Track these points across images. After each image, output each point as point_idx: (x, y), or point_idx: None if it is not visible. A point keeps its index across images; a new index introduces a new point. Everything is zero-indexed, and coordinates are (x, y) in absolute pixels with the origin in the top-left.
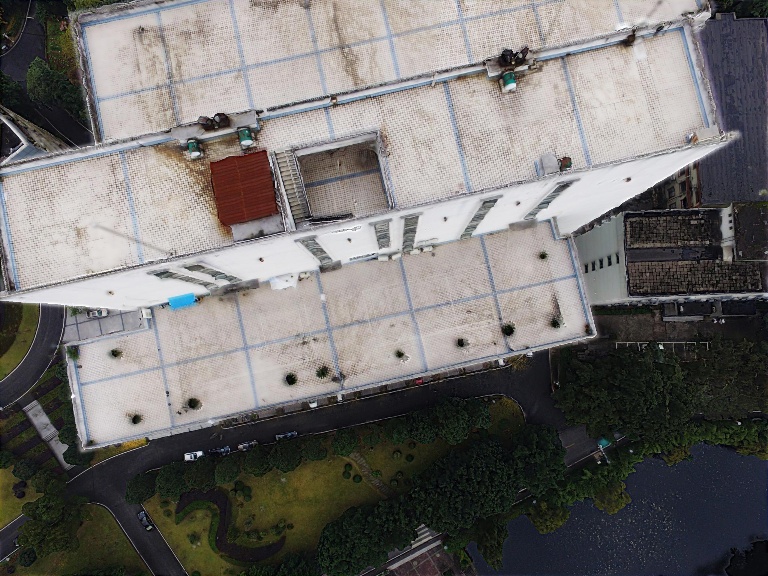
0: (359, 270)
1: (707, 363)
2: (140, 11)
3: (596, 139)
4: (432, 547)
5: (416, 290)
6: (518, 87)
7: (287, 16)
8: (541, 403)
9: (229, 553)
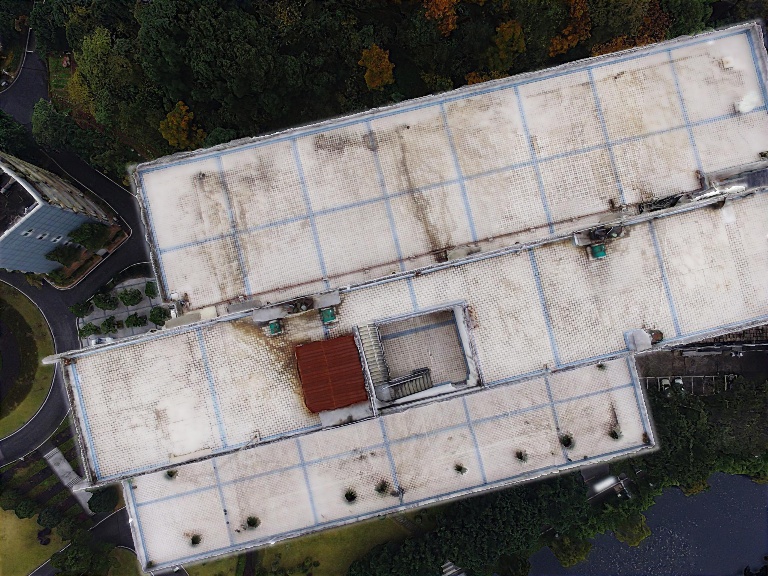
0: None
1: (729, 405)
2: (200, 157)
3: (685, 307)
4: None
5: (473, 401)
6: None
7: (354, 159)
8: None
9: None
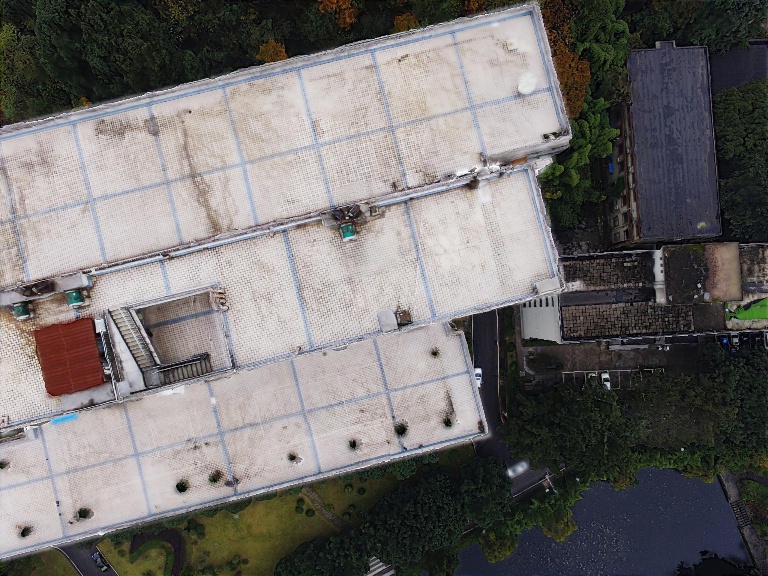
0: (249, 372)
1: (646, 398)
2: None
3: (440, 288)
4: None
5: (308, 390)
6: (360, 235)
7: (135, 144)
8: (490, 433)
9: None
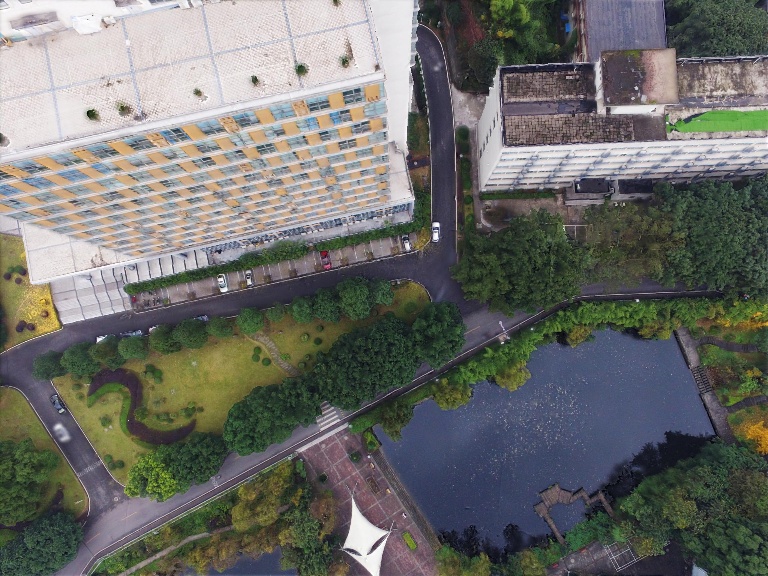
0: (163, 18)
1: (594, 227)
2: None
3: None
4: (340, 430)
5: (216, 36)
6: None
7: None
8: (447, 287)
9: (140, 436)
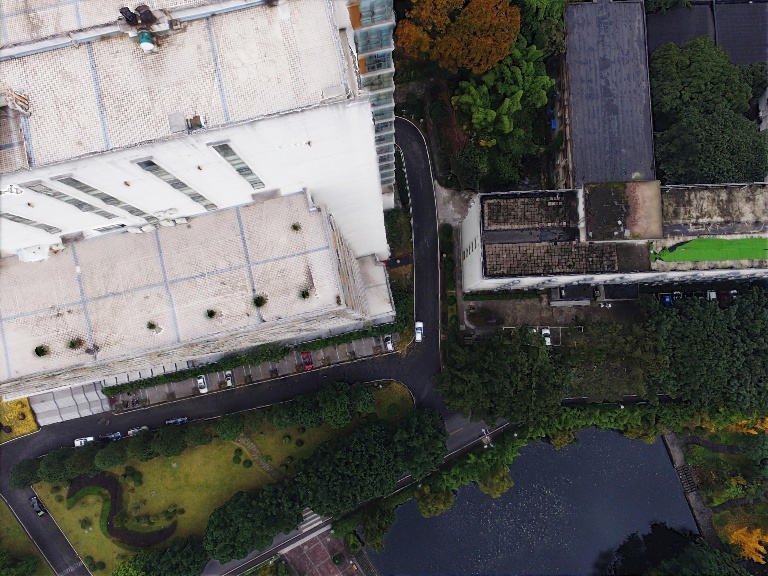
0: (114, 242)
1: (577, 346)
2: None
3: (236, 99)
4: (323, 531)
5: (171, 262)
6: (161, 47)
7: None
8: (431, 388)
9: (121, 538)
